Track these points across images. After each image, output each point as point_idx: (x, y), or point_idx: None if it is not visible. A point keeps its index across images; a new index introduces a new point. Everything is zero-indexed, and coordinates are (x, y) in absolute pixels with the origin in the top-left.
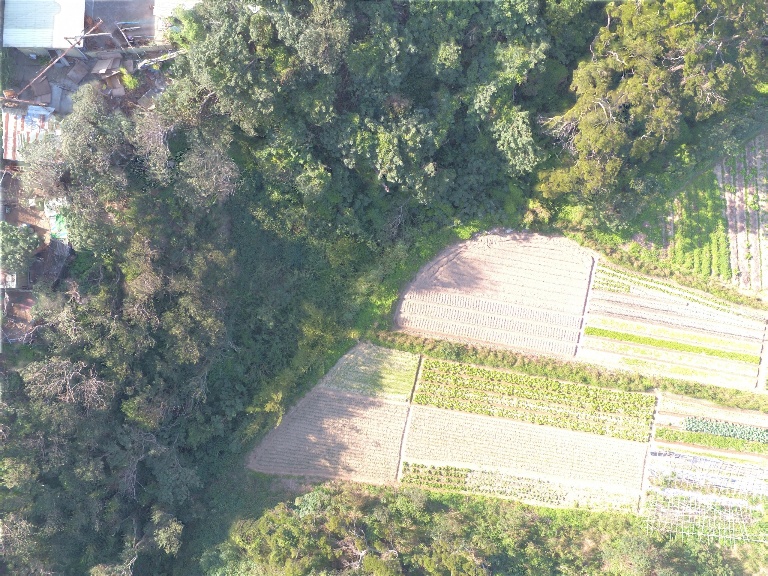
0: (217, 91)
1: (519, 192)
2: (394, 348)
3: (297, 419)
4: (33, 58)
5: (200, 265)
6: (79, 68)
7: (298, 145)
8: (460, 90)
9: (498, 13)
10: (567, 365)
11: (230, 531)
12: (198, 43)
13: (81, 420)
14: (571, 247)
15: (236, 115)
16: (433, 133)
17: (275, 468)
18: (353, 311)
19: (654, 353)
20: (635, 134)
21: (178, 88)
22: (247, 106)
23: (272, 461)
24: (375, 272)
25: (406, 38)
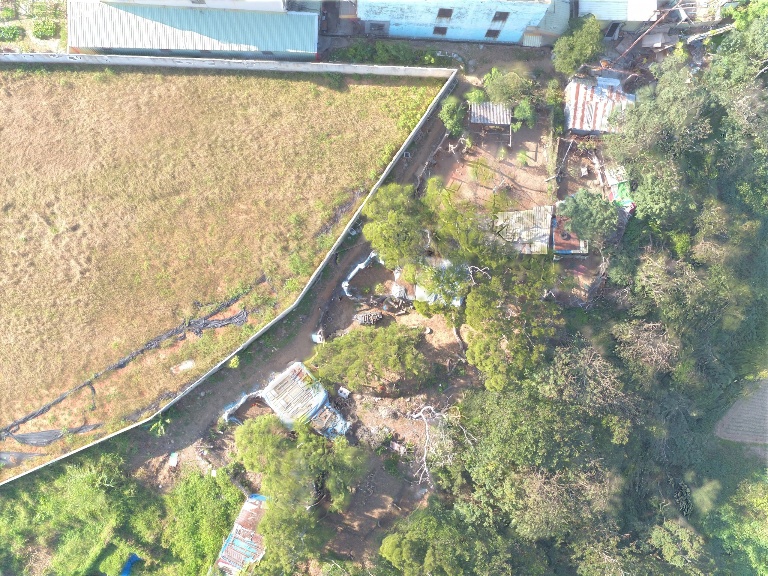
0: None
1: None
2: None
3: (761, 389)
4: None
5: (741, 234)
6: None
7: None
8: None
9: None
10: None
11: (727, 495)
12: None
13: (653, 382)
14: None
15: None
16: None
17: (742, 436)
18: None
19: None
20: None
21: (730, 62)
22: None
23: (739, 429)
24: None
25: None
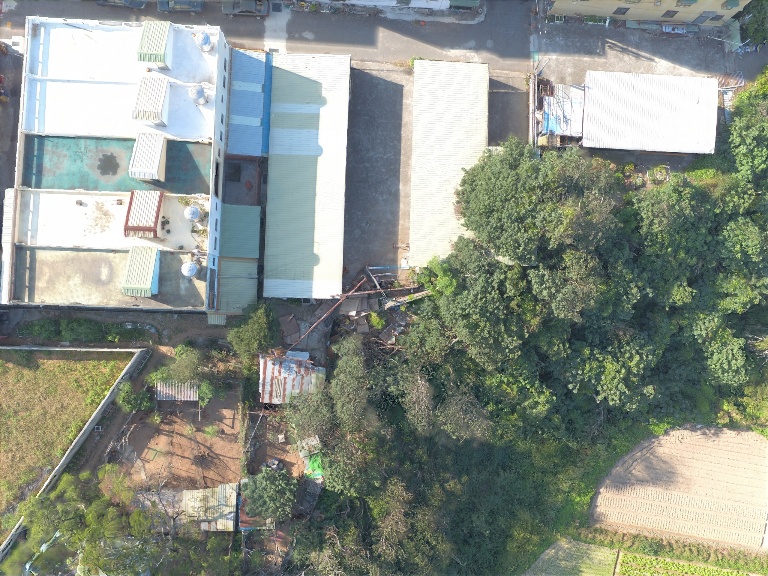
0: (472, 342)
1: (712, 391)
2: (594, 544)
3: None
4: (284, 299)
5: (441, 497)
6: (326, 307)
7: (529, 374)
8: (677, 313)
9: (729, 254)
10: (756, 558)
11: None
12: (454, 295)
13: None
14: (758, 441)
15: (482, 357)
16: None
17: None
18: (555, 508)
19: None
20: None
21: (426, 330)
22: (495, 351)
23: None
24: (576, 471)
25: (643, 281)
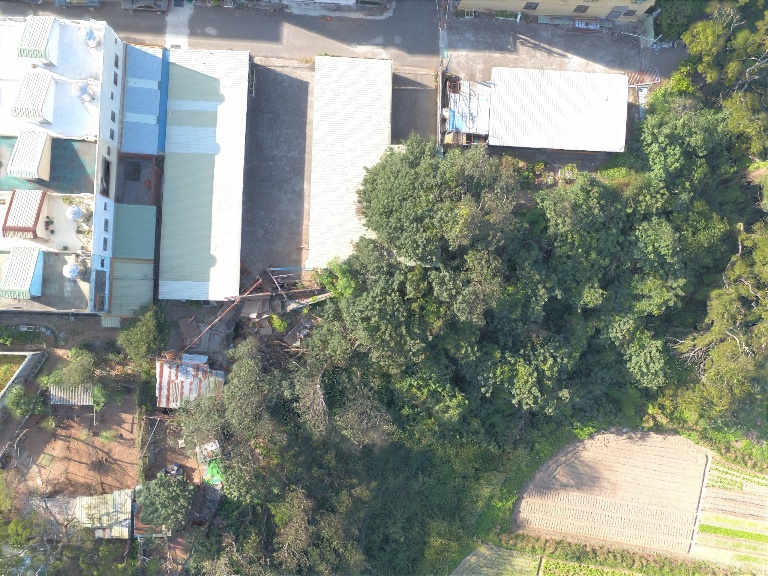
0: (372, 345)
1: (637, 394)
2: (515, 550)
3: None
4: (183, 301)
5: (347, 503)
6: None
7: (439, 377)
8: (594, 315)
9: (641, 255)
10: (683, 564)
11: None
12: (354, 297)
13: None
14: (686, 446)
15: (386, 360)
16: (568, 360)
17: None
18: (476, 514)
19: (765, 549)
20: (764, 359)
21: (328, 333)
22: (399, 355)
23: None
24: (497, 476)
25: (552, 283)
